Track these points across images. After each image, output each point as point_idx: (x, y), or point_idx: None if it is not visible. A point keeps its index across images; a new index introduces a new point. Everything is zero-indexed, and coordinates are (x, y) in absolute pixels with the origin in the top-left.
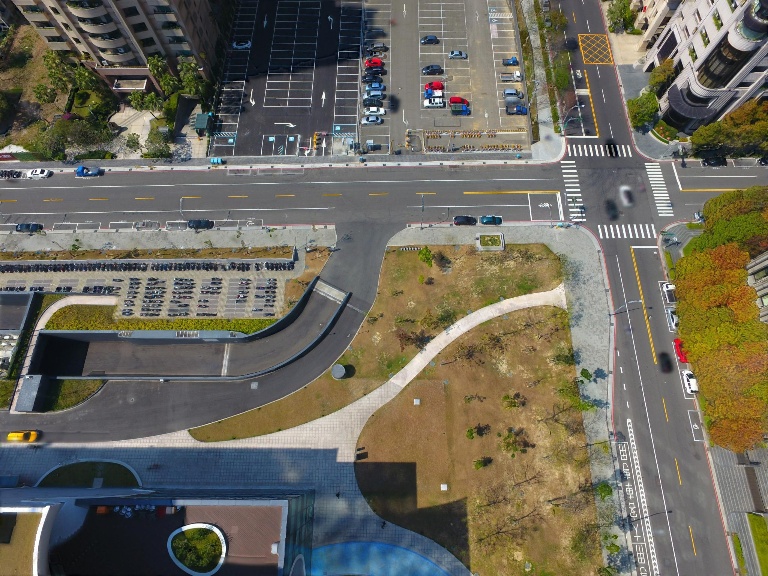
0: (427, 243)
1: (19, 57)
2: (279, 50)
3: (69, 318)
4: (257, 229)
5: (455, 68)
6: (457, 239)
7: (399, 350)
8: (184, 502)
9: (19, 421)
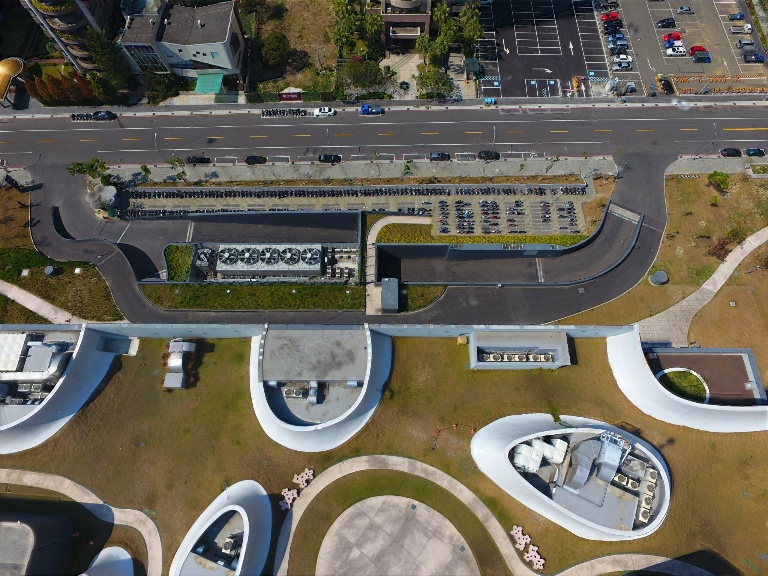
0: (702, 172)
1: (277, 10)
2: (519, 5)
3: (395, 234)
4: (542, 160)
5: (685, 22)
6: (728, 168)
7: (703, 261)
8: (663, 349)
9: (377, 320)
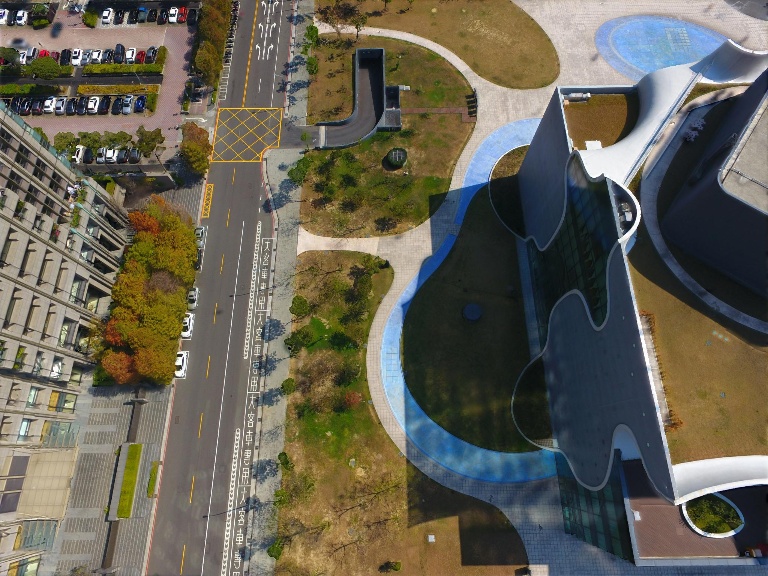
0: None
1: None
2: None
3: None
4: None
5: None
6: None
7: None
8: (746, 562)
9: None
